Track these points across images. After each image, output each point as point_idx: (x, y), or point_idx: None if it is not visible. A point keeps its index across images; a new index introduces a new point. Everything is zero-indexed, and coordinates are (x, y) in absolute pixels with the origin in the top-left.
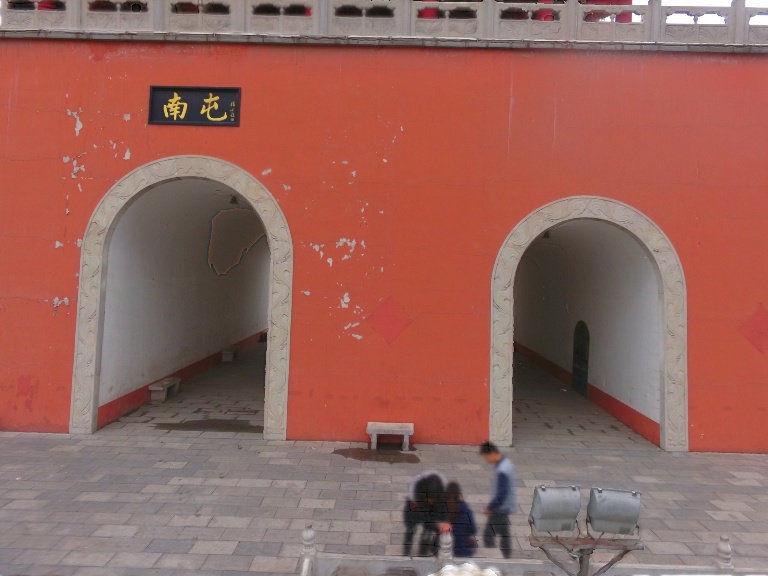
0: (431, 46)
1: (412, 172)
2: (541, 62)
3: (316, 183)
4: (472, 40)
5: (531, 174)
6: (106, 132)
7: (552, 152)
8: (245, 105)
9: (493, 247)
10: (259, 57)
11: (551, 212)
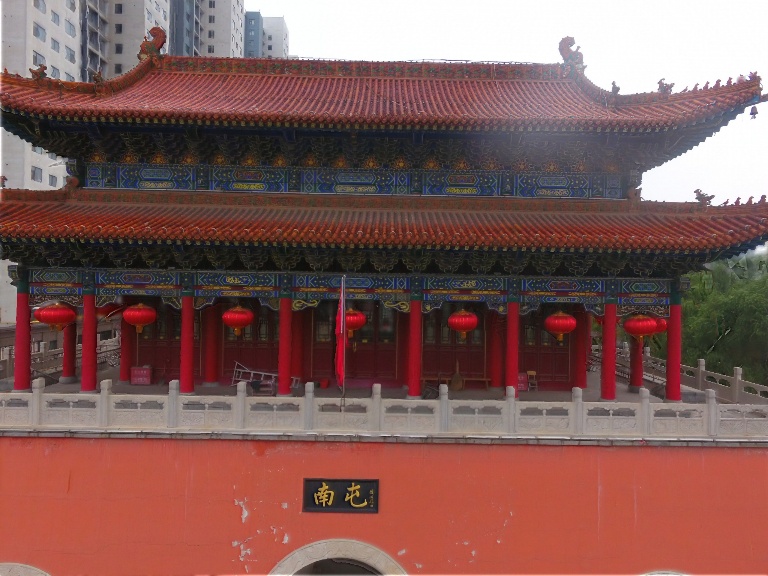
0: (533, 444)
1: (521, 551)
2: (622, 455)
3: (442, 561)
4: (566, 439)
5: (618, 551)
6: (267, 519)
7: (634, 532)
8: (382, 494)
9: None
10: (393, 452)
11: None
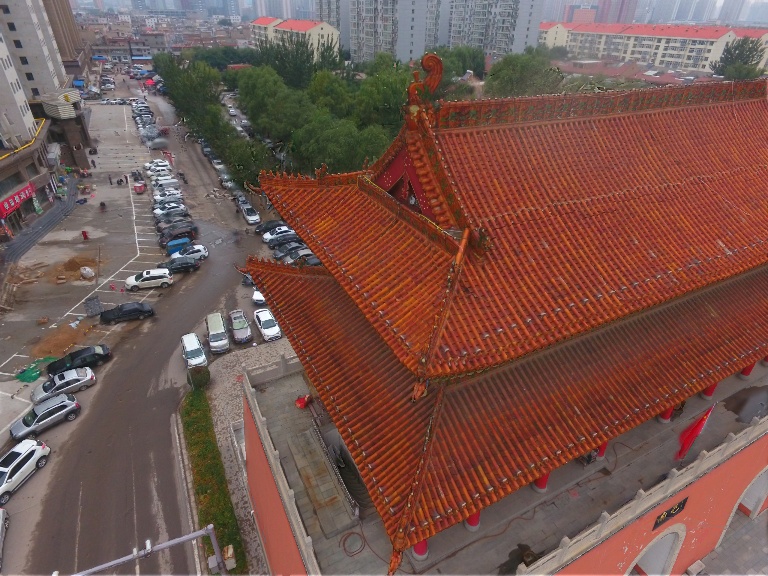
0: None
1: None
2: None
3: None
4: None
5: (759, 465)
6: None
7: None
8: None
9: (739, 495)
10: None
11: None
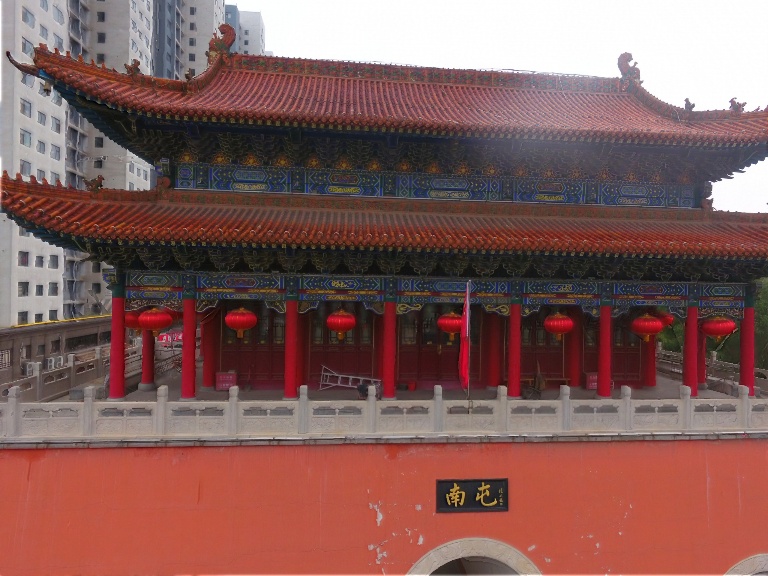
0: (649, 440)
1: (640, 541)
2: (726, 447)
3: (569, 555)
4: (678, 434)
5: (725, 537)
6: (402, 521)
7: (739, 519)
8: (511, 492)
9: None
10: (520, 452)
11: (742, 568)
